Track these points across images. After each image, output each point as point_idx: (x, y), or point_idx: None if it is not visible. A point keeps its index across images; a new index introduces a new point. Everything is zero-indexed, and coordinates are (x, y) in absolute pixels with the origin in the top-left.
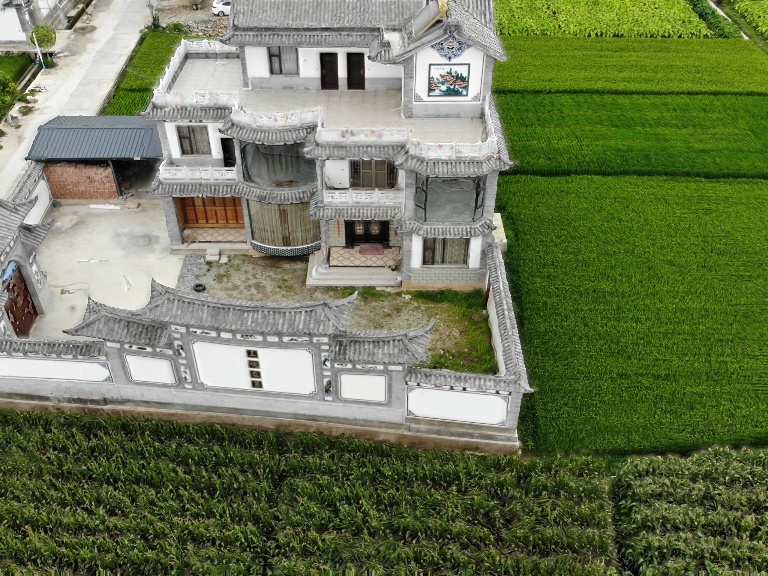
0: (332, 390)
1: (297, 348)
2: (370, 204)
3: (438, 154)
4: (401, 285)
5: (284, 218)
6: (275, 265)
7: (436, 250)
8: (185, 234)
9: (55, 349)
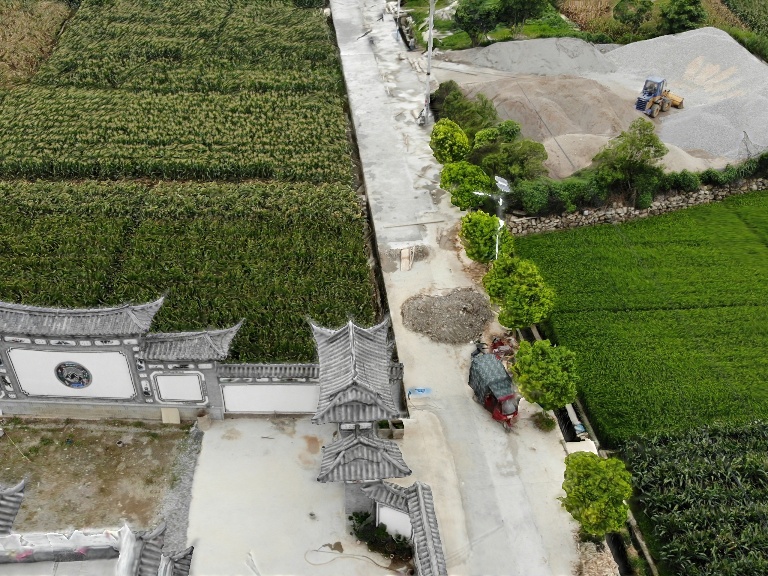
0: None
1: None
2: None
3: None
4: None
5: None
6: None
7: None
8: None
9: (266, 364)
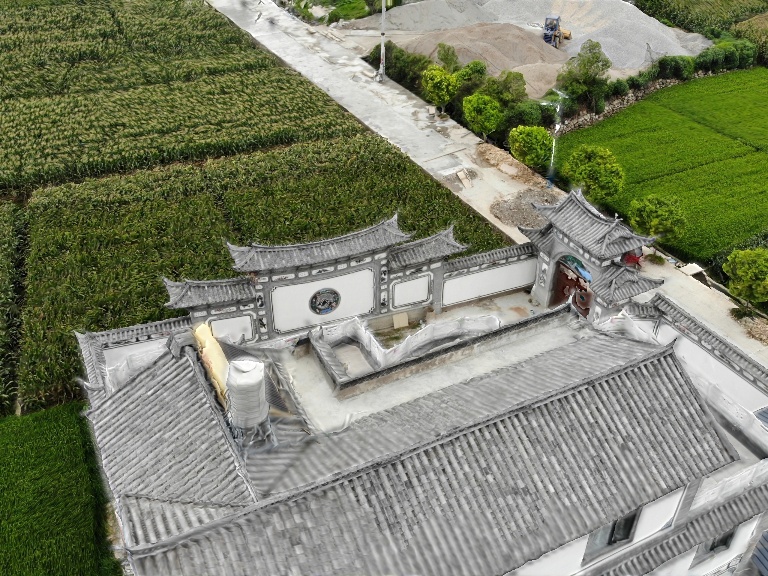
0: None
1: None
2: None
3: None
4: None
5: None
6: None
7: None
8: None
9: None
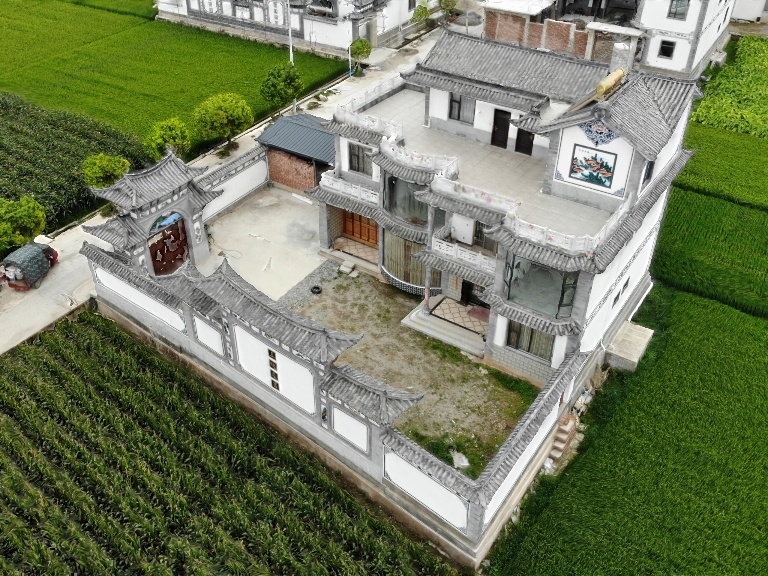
0: (327, 419)
1: (303, 365)
2: (472, 265)
3: (529, 234)
4: (483, 358)
5: (408, 254)
6: (391, 295)
7: (523, 335)
8: (336, 241)
9: (152, 290)
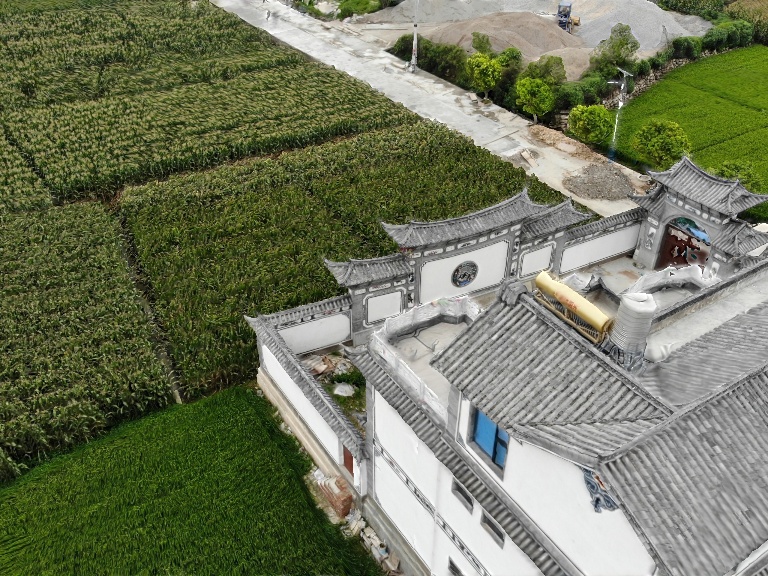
0: None
1: None
2: None
3: (431, 313)
4: None
5: None
6: None
7: None
8: None
9: None
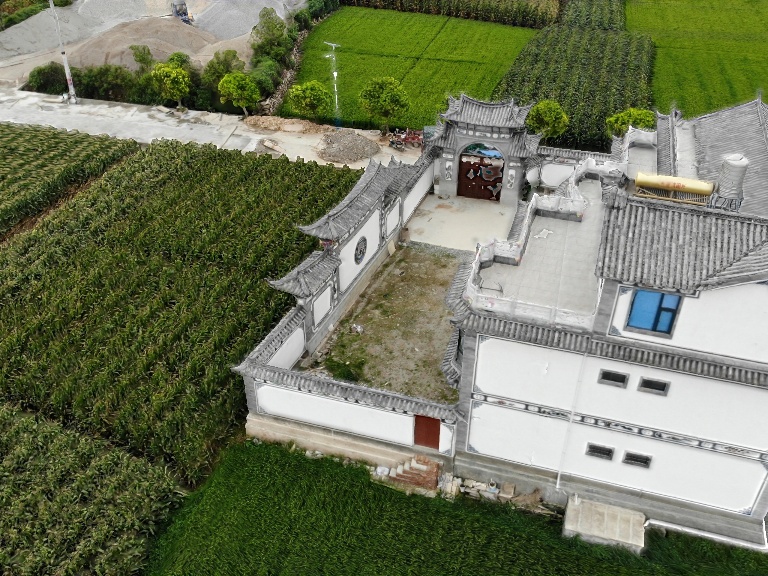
0: None
1: None
2: None
3: None
4: None
5: None
6: None
7: None
8: None
9: None
